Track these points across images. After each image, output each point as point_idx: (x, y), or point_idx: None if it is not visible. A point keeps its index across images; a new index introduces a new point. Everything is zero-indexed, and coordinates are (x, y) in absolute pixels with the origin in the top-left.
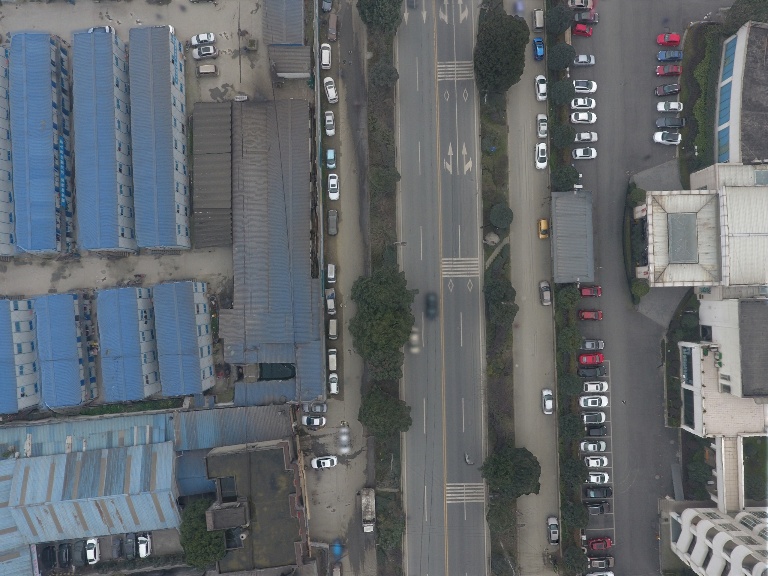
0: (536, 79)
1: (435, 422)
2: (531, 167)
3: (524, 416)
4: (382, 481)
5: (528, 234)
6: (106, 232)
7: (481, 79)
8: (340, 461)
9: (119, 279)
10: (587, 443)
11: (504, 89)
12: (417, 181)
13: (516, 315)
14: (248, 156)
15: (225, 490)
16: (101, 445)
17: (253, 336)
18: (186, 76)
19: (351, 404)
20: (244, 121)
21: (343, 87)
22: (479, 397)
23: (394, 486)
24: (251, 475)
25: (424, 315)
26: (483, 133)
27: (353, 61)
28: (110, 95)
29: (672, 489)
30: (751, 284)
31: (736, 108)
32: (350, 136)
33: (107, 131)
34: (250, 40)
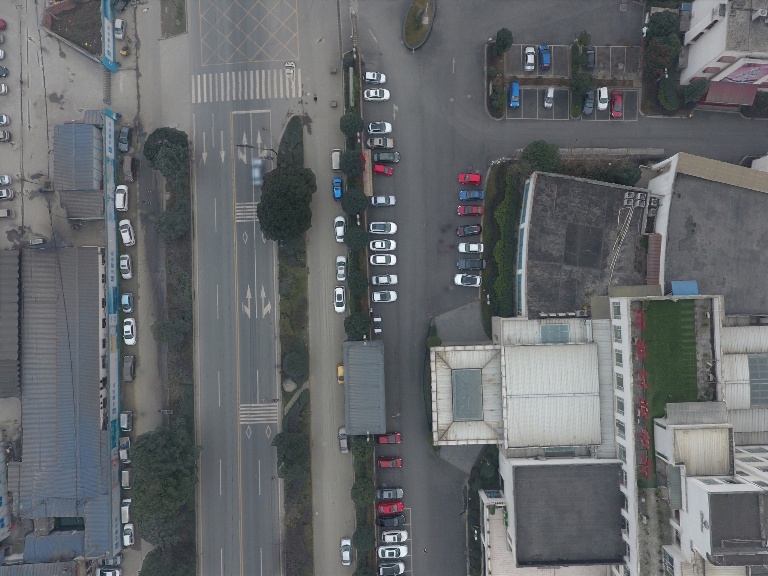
0: (334, 221)
1: (232, 573)
2: (331, 310)
3: (324, 565)
4: None
5: (329, 378)
6: None
7: (265, 230)
8: None
9: None
10: None
11: (291, 239)
12: (215, 325)
13: (316, 461)
14: (37, 305)
15: None
16: None
17: (41, 490)
18: None
19: None
20: (33, 269)
21: (142, 228)
22: (278, 547)
23: None
24: None
25: (221, 463)
26: (281, 276)
27: (152, 201)
28: None
29: None
30: (530, 446)
31: (524, 259)
32: (148, 278)
33: None
34: (46, 182)
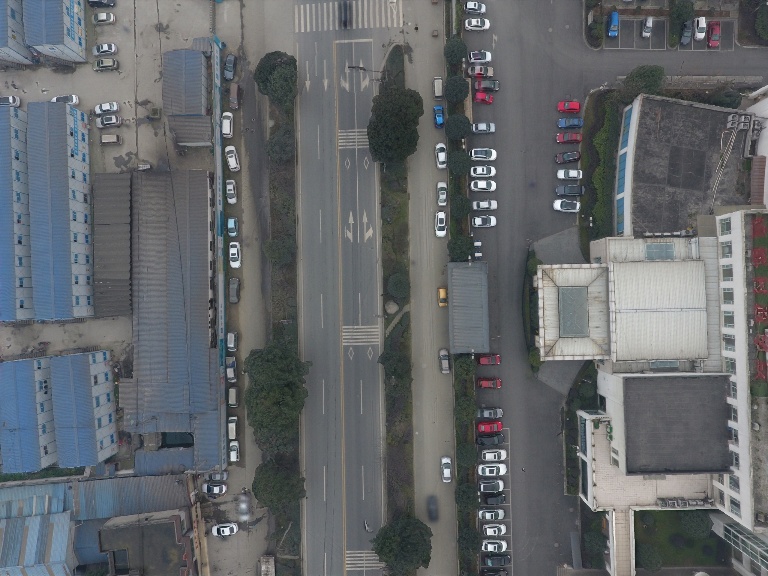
0: (436, 147)
1: (335, 489)
2: (432, 235)
3: (424, 483)
4: (282, 548)
5: (429, 301)
6: (3, 305)
7: (374, 152)
8: (241, 528)
9: (24, 346)
10: (485, 512)
11: (399, 161)
12: (318, 249)
13: (416, 382)
14: (148, 226)
15: (118, 562)
16: (0, 515)
17: (152, 406)
18: (90, 144)
19: (252, 471)
20: (144, 191)
21: (246, 155)
22: (379, 465)
23: (293, 554)
24: (143, 548)
25: (324, 383)
26: (383, 201)
27: (256, 129)
28: (7, 169)
29: (571, 557)
30: (638, 360)
31: (628, 180)
32: (252, 204)
33: (4, 205)
34: (153, 109)
